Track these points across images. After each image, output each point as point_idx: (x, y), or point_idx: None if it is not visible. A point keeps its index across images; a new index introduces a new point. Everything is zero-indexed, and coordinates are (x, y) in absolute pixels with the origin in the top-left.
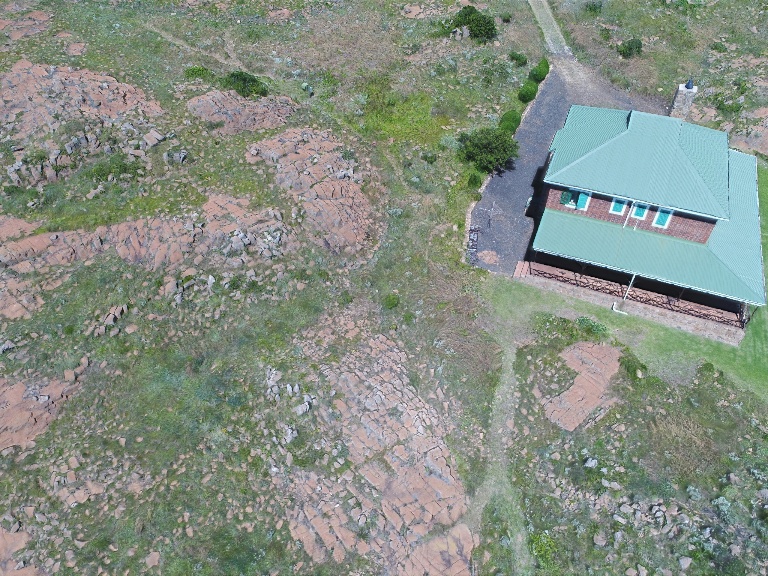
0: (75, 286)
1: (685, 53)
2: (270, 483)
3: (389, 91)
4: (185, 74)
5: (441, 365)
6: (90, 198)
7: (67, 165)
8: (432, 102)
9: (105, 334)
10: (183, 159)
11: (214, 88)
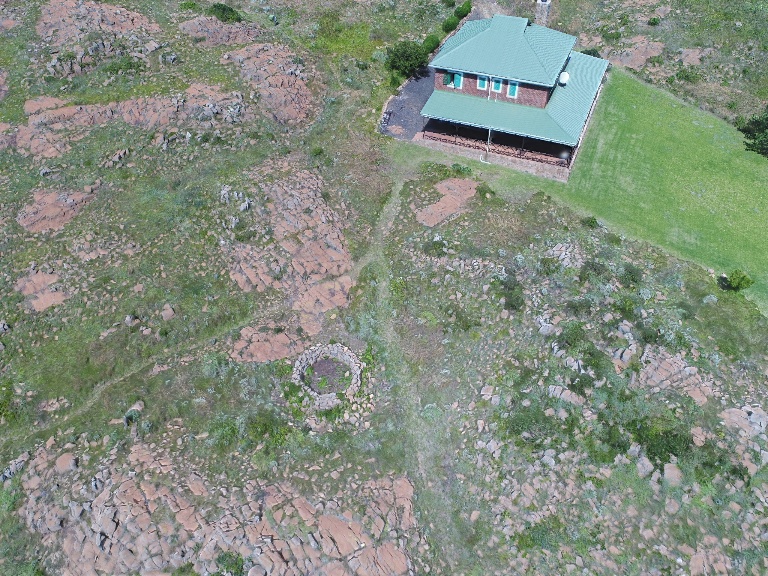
0: (93, 138)
1: None
2: (219, 250)
3: (338, 22)
4: (180, 7)
5: (347, 189)
6: (105, 85)
7: (89, 63)
8: (370, 29)
9: (113, 167)
10: (173, 60)
11: None
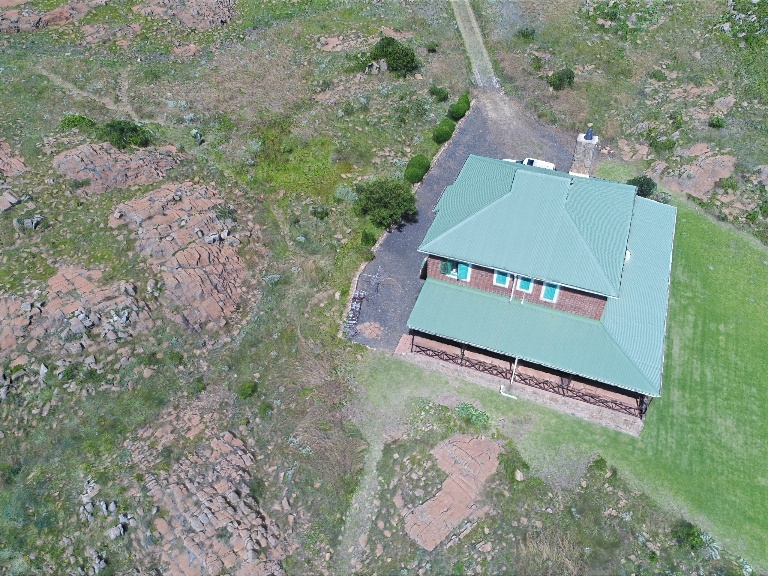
0: None
1: (620, 83)
2: None
3: (288, 136)
4: (62, 124)
5: (292, 468)
6: None
7: None
8: (333, 147)
9: None
10: (35, 225)
11: (89, 140)
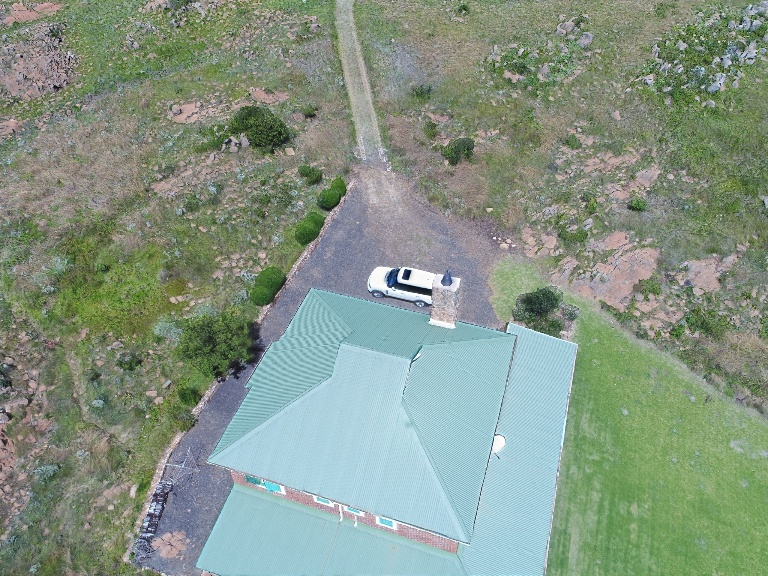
0: None
1: (527, 153)
2: None
3: (108, 246)
4: None
5: None
6: None
7: None
8: (163, 261)
9: None
10: None
11: None
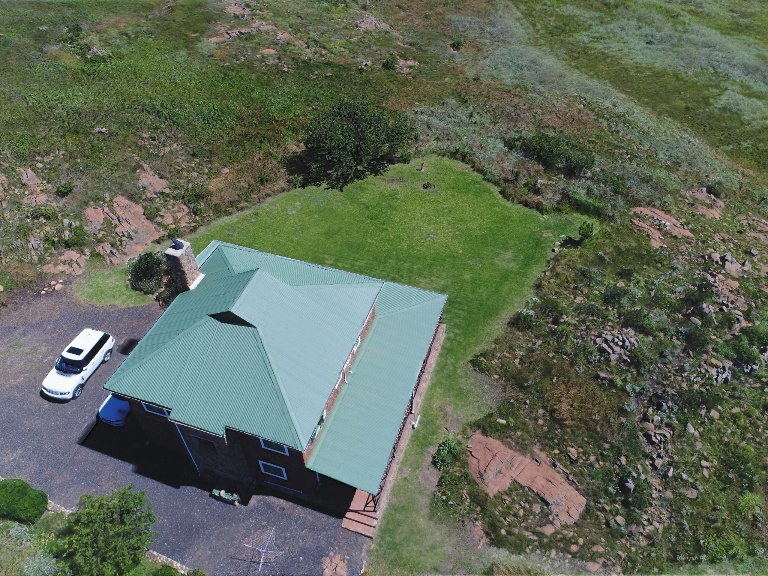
0: None
1: None
2: None
3: None
4: None
5: None
6: None
7: None
8: None
9: None
10: None
11: None
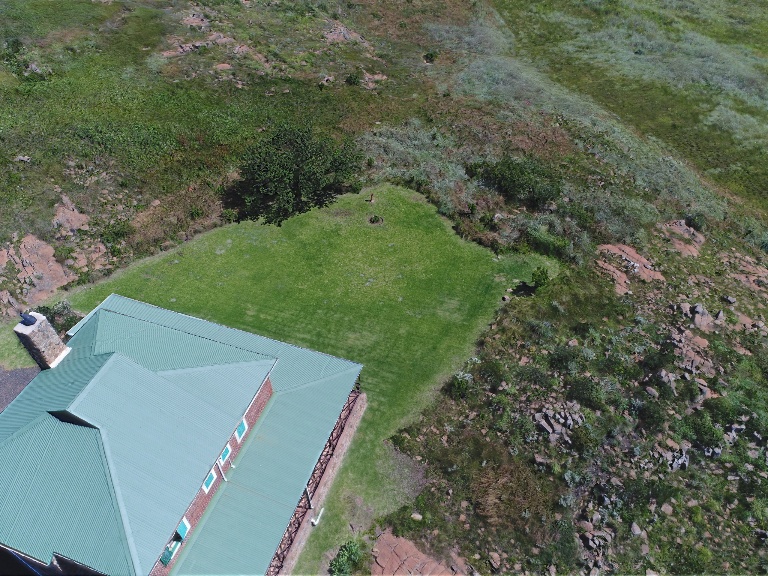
0: None
1: None
2: None
3: None
4: None
5: None
6: None
7: None
8: None
9: None
10: None
11: None
